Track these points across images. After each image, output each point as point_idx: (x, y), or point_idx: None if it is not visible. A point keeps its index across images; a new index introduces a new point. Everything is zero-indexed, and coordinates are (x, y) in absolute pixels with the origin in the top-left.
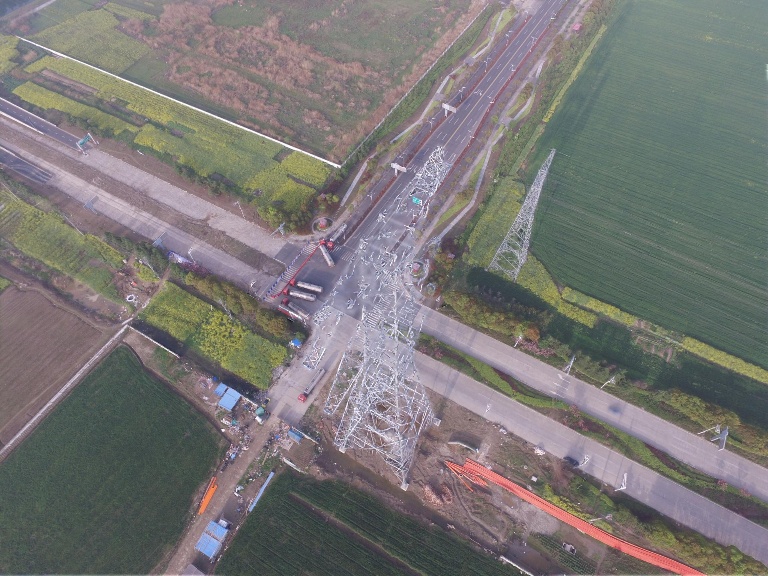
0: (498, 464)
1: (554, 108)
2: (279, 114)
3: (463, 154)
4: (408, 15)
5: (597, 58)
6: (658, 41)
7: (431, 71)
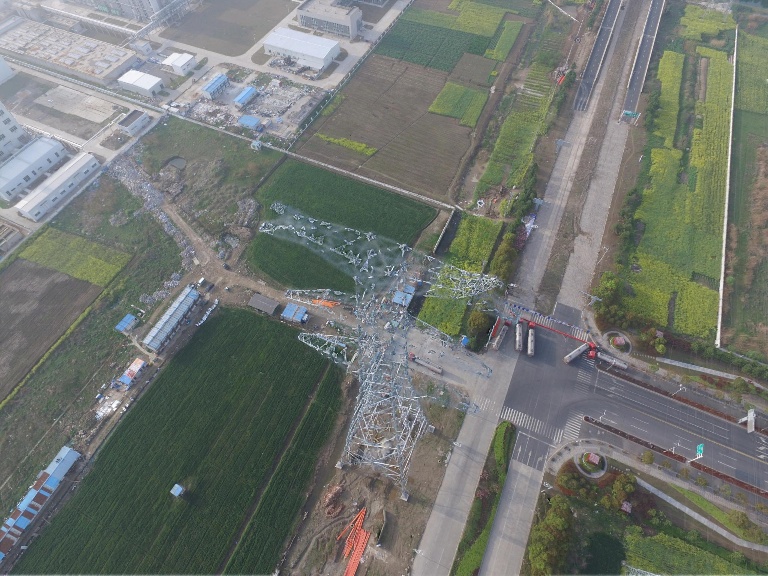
0: (367, 571)
1: None
2: None
3: None
4: None
5: None
6: None
7: None
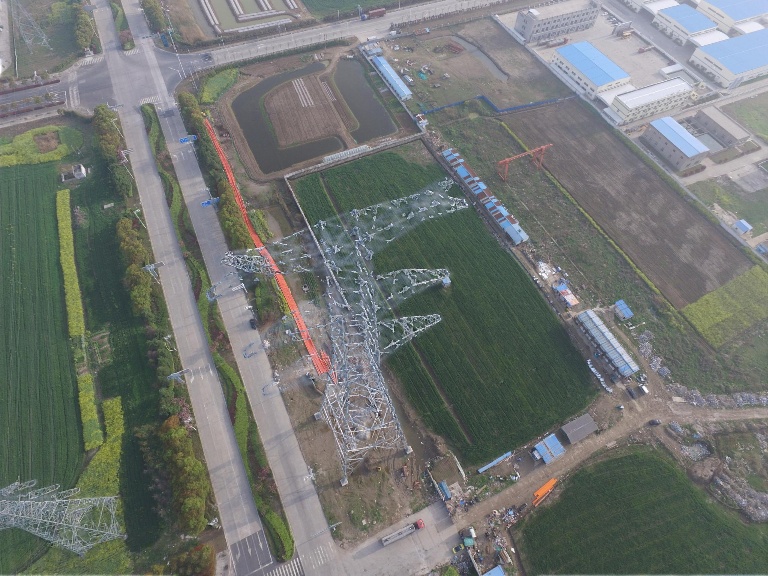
0: None
1: None
2: None
3: None
4: None
5: None
6: None
7: None
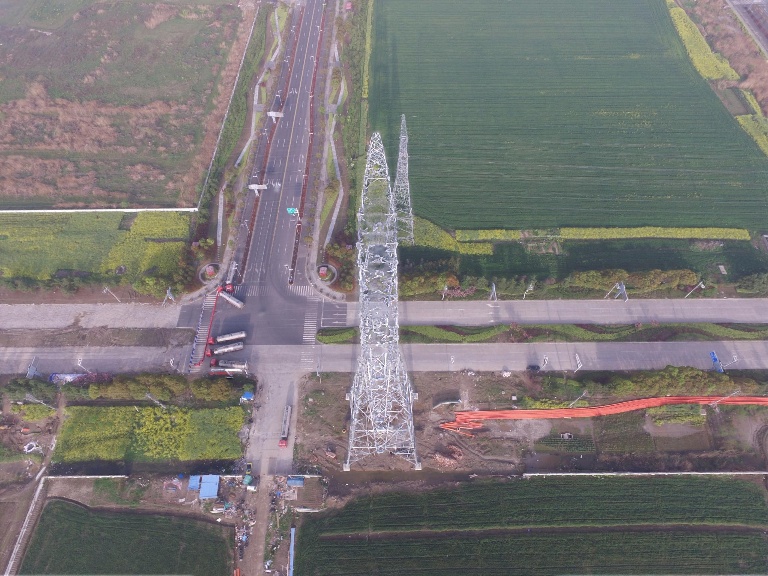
0: (481, 402)
1: (367, 83)
2: (99, 182)
3: (310, 152)
4: (185, 39)
5: (379, 28)
6: None
7: (238, 86)
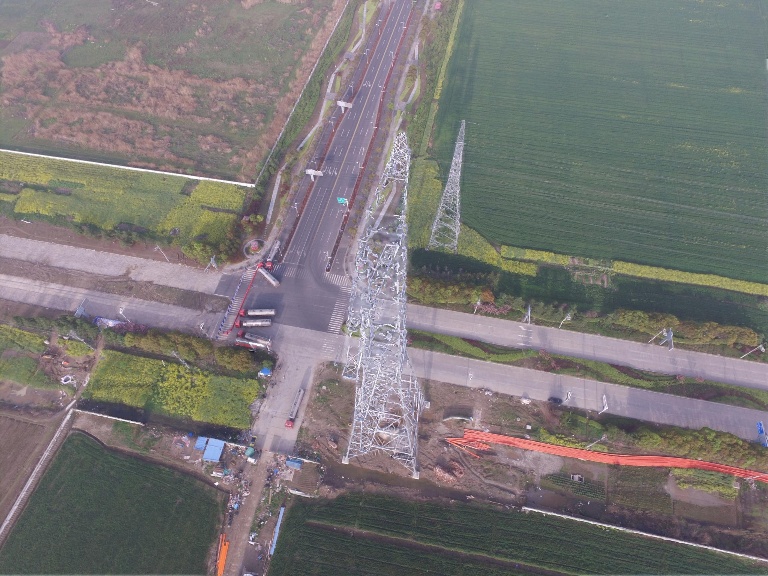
0: (493, 425)
1: (441, 85)
2: (172, 147)
3: (371, 146)
4: (275, 22)
5: (464, 31)
6: (511, 6)
7: (315, 72)
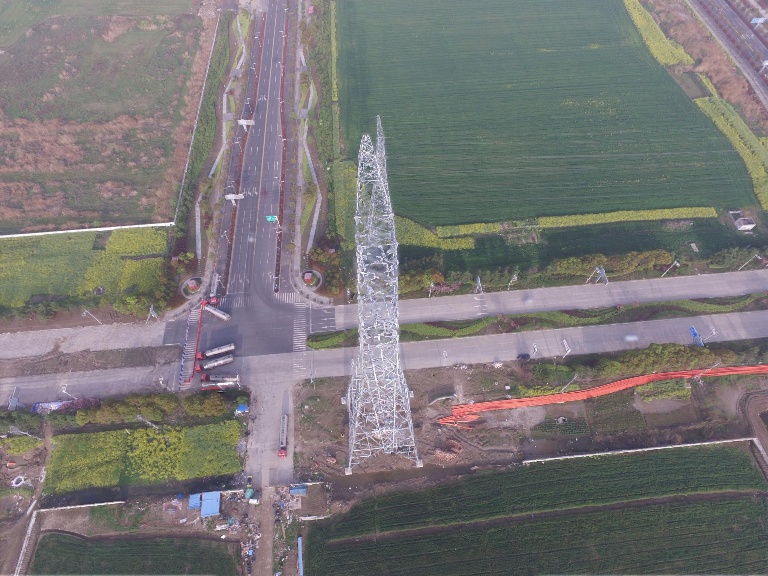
0: (476, 395)
1: (336, 86)
2: (68, 202)
3: (284, 158)
4: (146, 51)
5: (343, 31)
6: (381, 0)
7: (205, 96)
